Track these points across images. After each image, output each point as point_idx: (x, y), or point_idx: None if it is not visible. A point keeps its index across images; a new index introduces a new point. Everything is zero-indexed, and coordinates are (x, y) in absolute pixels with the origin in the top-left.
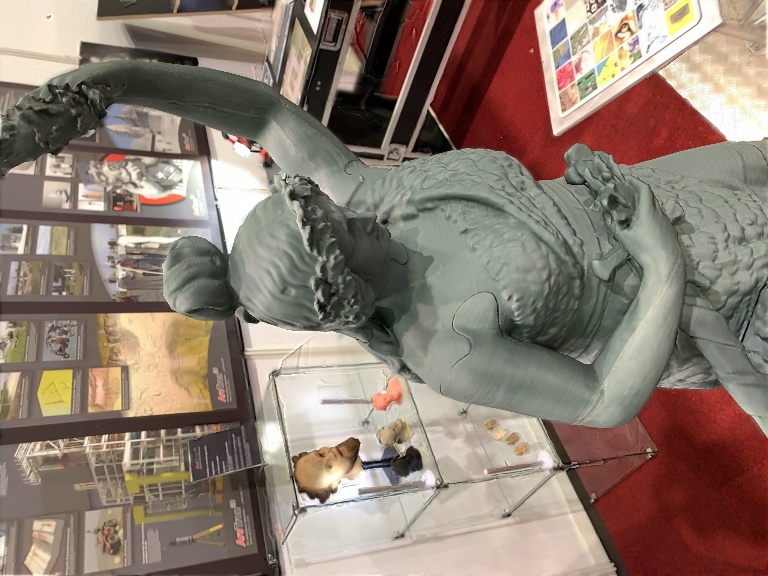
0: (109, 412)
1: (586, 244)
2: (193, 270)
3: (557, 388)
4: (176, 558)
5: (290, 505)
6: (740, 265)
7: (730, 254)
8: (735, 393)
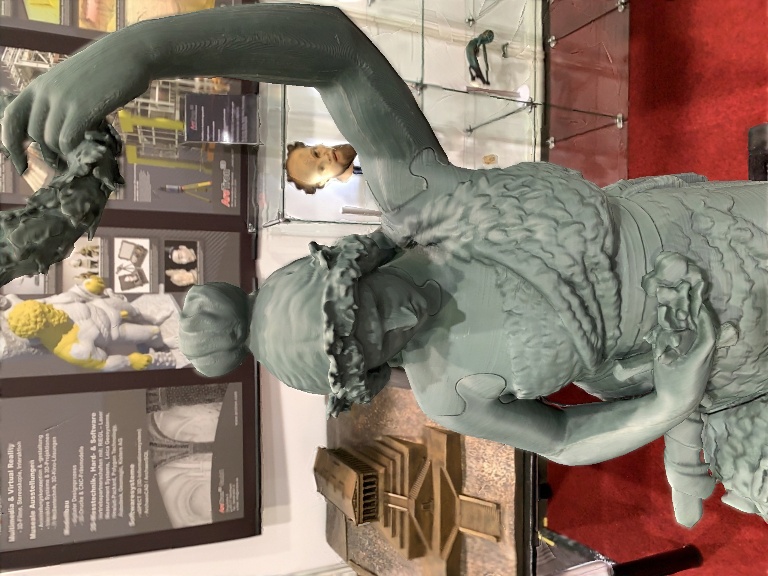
0: (102, 33)
1: (623, 337)
2: (212, 347)
3: (524, 443)
4: (165, 202)
5: (277, 178)
6: (755, 379)
7: (754, 368)
8: (669, 472)
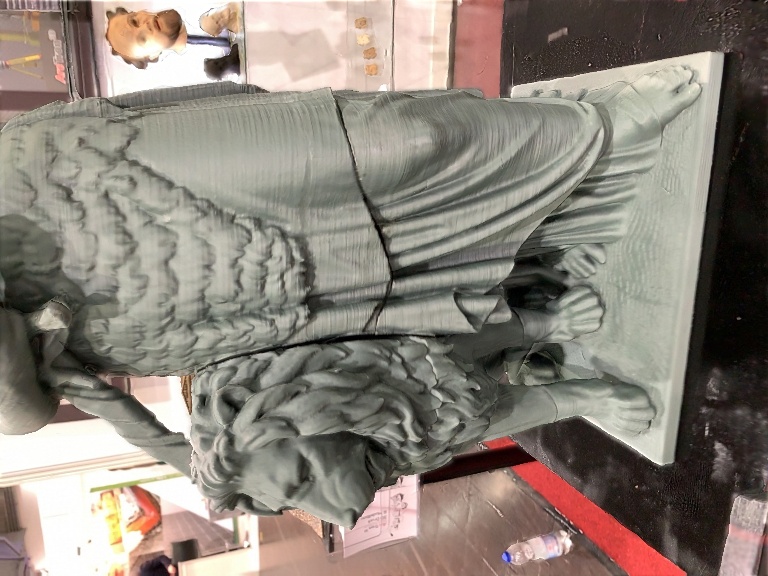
0: None
1: None
2: None
3: None
4: None
5: None
6: (171, 353)
7: (160, 343)
8: None
